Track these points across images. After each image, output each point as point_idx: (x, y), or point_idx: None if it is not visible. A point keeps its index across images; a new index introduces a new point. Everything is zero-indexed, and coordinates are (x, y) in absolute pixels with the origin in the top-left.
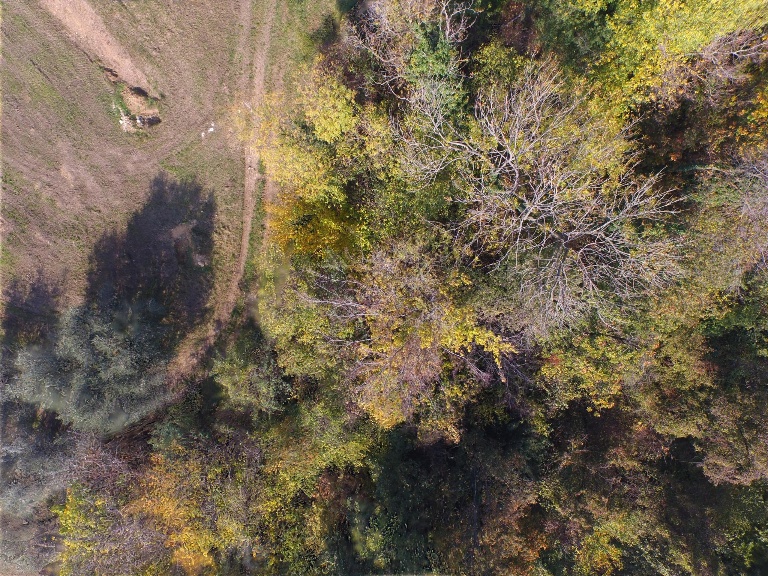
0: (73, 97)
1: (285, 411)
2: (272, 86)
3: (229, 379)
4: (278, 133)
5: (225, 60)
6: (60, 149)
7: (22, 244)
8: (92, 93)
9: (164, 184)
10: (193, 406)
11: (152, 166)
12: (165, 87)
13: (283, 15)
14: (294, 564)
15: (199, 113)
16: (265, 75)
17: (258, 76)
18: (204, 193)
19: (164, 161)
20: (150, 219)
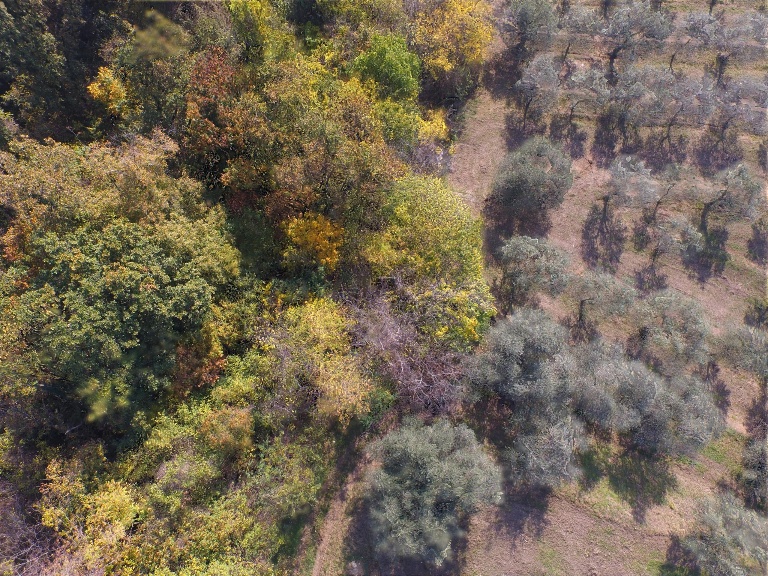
0: None
1: (253, 443)
2: None
3: None
4: None
5: None
6: None
7: (532, 574)
8: None
9: None
10: None
11: None
12: None
13: None
14: None
15: None
16: None
17: None
18: None
19: None
20: None
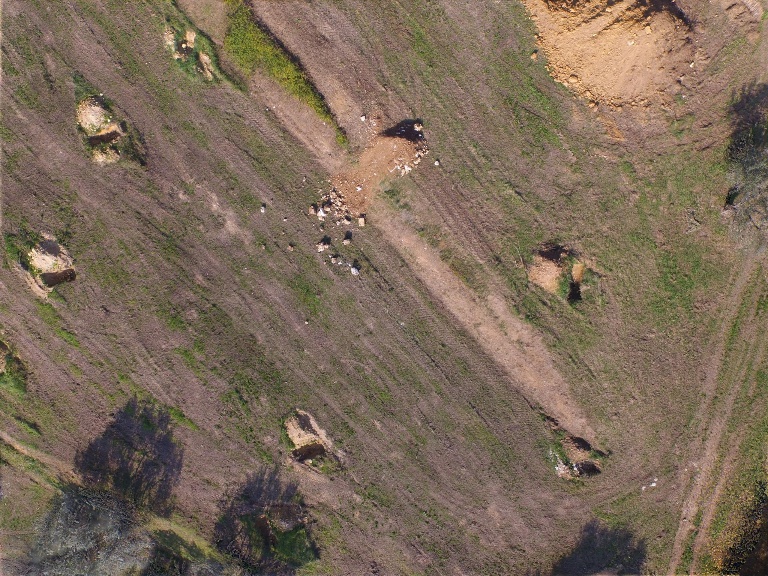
0: (509, 441)
1: None
2: (726, 451)
3: None
4: (723, 492)
5: (681, 424)
6: (490, 489)
7: None
8: (530, 439)
9: (594, 530)
10: None
11: (584, 512)
12: (615, 445)
13: (750, 388)
14: None
15: (643, 468)
16: (721, 441)
17: (712, 440)
18: (633, 540)
19: (598, 509)
20: (576, 562)
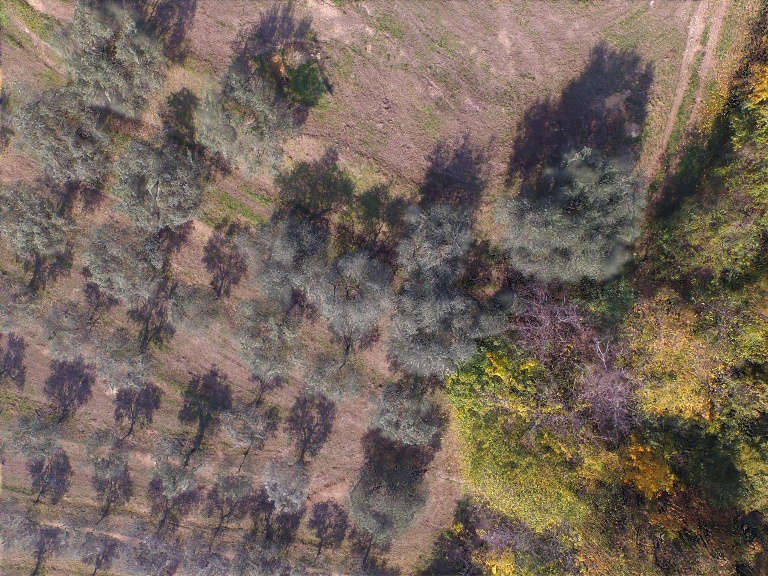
0: None
1: (745, 274)
2: None
3: (714, 233)
4: (730, 4)
5: None
6: (500, 14)
7: (451, 109)
8: None
9: (603, 53)
10: (593, 283)
11: (594, 34)
12: None
13: None
14: (730, 433)
15: None
16: None
17: None
18: (641, 64)
19: (607, 29)
20: (585, 88)
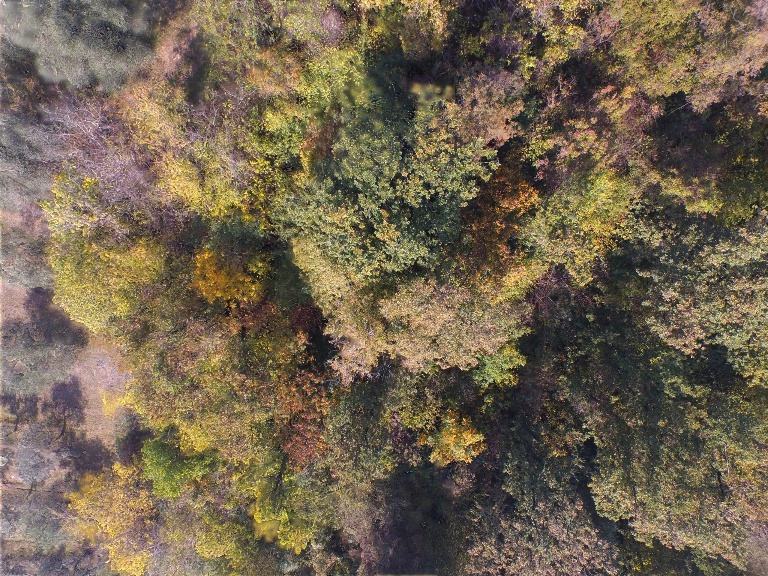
0: None
1: None
2: None
3: None
4: None
5: None
6: None
7: None
8: None
9: None
10: None
11: None
12: None
13: None
14: (285, 231)
15: None
16: None
17: None
18: None
19: None
20: None
